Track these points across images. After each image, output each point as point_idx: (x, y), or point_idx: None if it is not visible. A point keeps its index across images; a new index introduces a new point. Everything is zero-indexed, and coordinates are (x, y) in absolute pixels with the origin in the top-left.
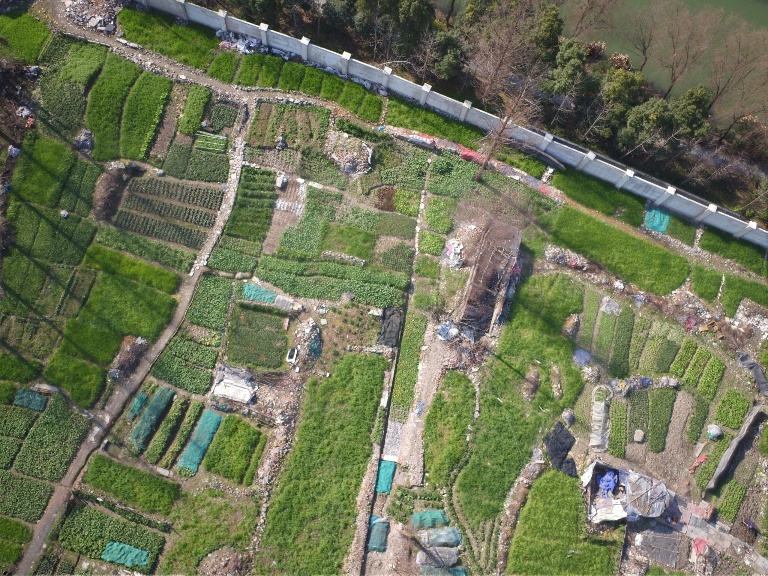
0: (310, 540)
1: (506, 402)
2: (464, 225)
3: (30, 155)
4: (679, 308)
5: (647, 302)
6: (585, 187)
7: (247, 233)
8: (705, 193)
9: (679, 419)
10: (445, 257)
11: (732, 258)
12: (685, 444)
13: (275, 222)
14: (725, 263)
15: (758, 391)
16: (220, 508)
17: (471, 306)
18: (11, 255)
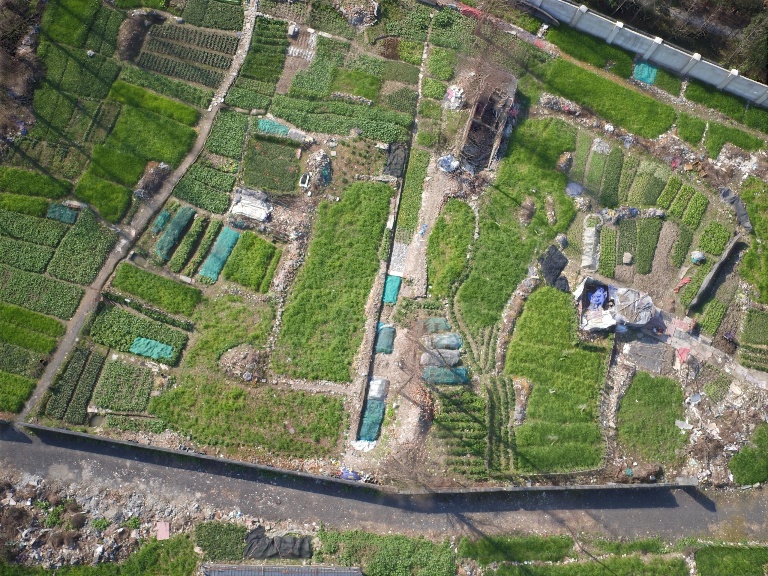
0: (322, 341)
1: (504, 226)
2: (464, 73)
3: (58, 1)
4: (665, 150)
5: (635, 143)
6: (578, 42)
7: (261, 75)
8: (690, 49)
9: (665, 245)
10: (446, 100)
11: (715, 108)
12: (670, 267)
13: (287, 66)
14: (709, 112)
15: (739, 223)
16: (239, 311)
17: (471, 141)
18: (41, 88)
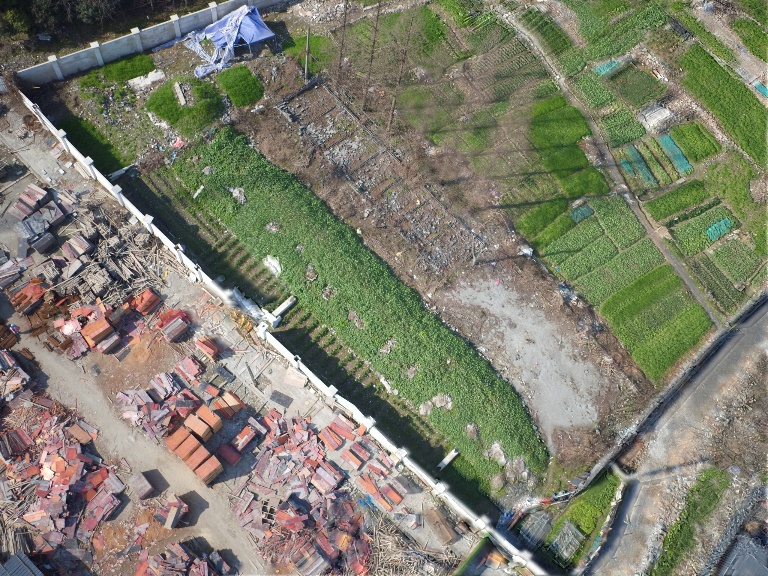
0: None
1: (761, 7)
2: None
3: (403, 108)
4: None
5: None
6: None
7: (555, 46)
8: None
9: None
10: None
11: None
12: None
13: (559, 29)
14: None
15: None
16: (725, 168)
17: None
18: (469, 162)
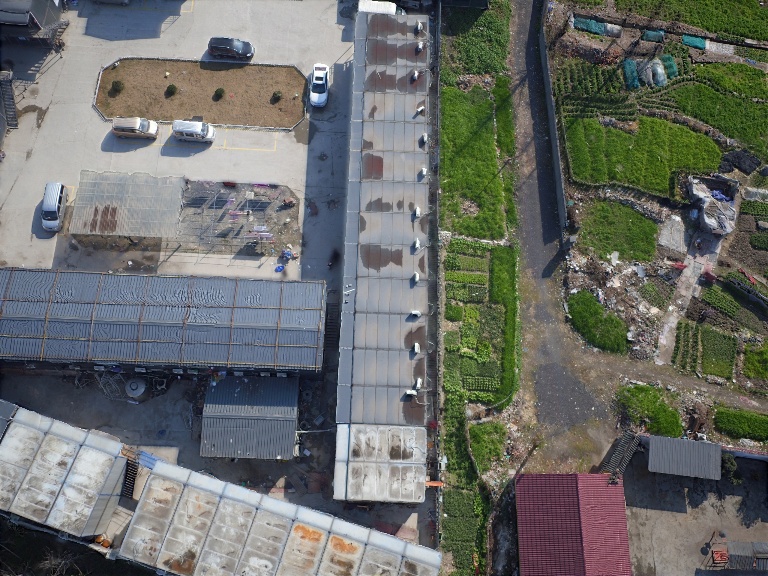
0: None
1: None
2: None
3: None
4: None
5: None
6: None
7: None
8: None
9: None
10: None
11: None
12: (762, 267)
13: None
14: None
15: None
16: None
17: None
18: None
